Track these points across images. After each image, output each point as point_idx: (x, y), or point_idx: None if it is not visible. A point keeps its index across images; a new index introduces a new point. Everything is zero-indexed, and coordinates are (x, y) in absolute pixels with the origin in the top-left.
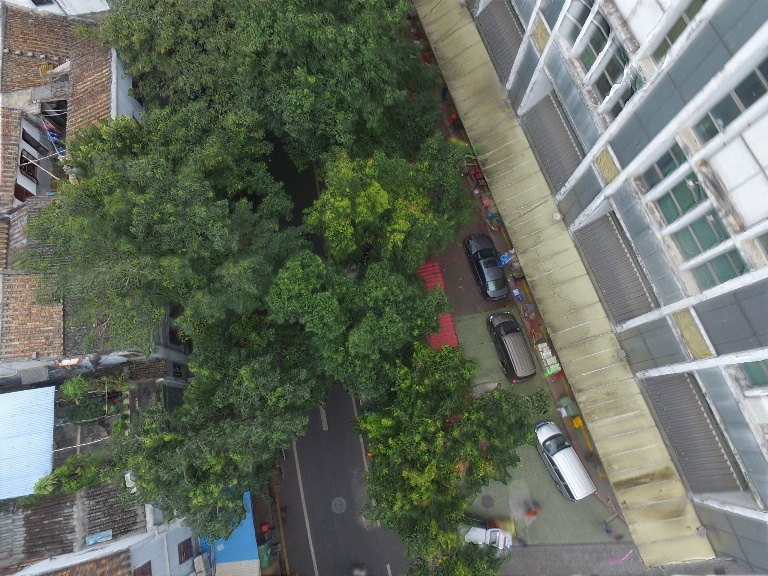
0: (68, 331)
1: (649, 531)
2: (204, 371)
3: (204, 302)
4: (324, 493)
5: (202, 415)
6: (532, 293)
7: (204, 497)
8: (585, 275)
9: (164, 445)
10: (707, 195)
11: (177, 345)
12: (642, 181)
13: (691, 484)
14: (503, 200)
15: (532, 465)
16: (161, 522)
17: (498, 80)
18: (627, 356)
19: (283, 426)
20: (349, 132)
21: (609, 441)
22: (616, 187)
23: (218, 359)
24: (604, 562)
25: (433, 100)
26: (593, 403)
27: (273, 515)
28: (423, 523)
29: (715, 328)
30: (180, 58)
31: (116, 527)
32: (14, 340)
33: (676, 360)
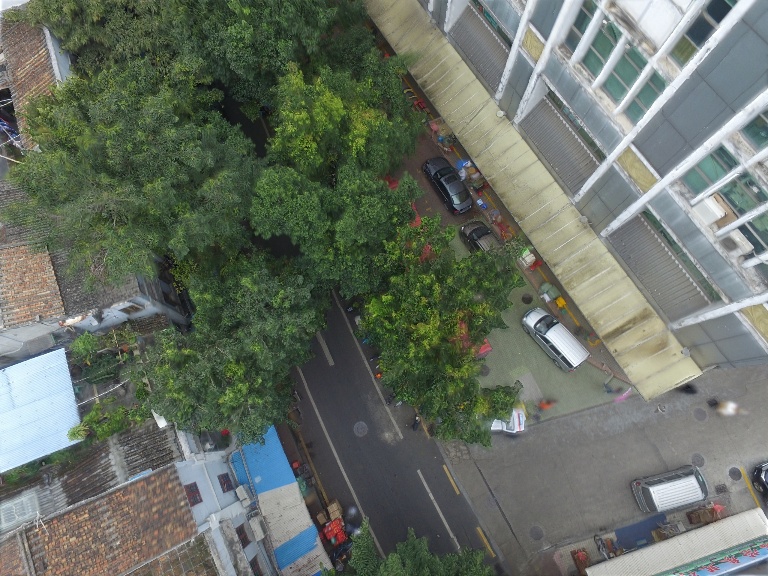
0: (65, 293)
1: (642, 369)
2: (207, 295)
3: (193, 220)
4: (344, 421)
5: (214, 332)
6: (494, 190)
7: (234, 395)
8: (537, 161)
9: (185, 362)
10: (621, 32)
11: (172, 306)
12: (566, 48)
13: (668, 315)
14: (449, 114)
15: (529, 351)
16: (197, 453)
17: (420, 6)
18: (589, 222)
19: (293, 321)
20: (292, 60)
21: (590, 302)
22: (545, 61)
23: (217, 289)
24: (611, 419)
25: (364, 31)
26: (569, 273)
27: (300, 453)
28: (439, 374)
29: (654, 154)
30: (113, 25)
31: (155, 465)
32: (14, 308)
33: (630, 202)
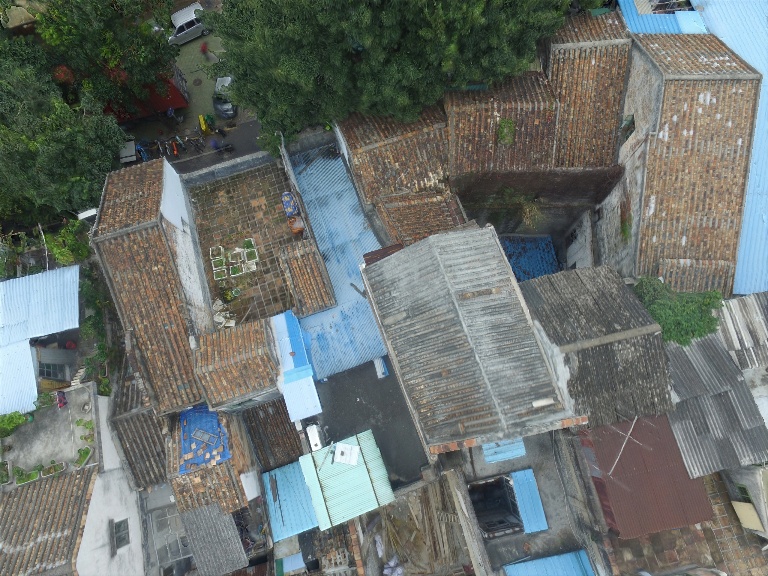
0: None
1: None
2: None
3: None
4: None
5: None
6: None
7: None
8: None
9: None
10: None
11: None
12: None
13: None
14: None
15: (192, 51)
16: None
17: None
18: None
19: None
20: None
21: None
22: None
23: None
24: None
25: None
26: None
27: None
28: None
29: None
30: None
31: None
32: None
33: None
